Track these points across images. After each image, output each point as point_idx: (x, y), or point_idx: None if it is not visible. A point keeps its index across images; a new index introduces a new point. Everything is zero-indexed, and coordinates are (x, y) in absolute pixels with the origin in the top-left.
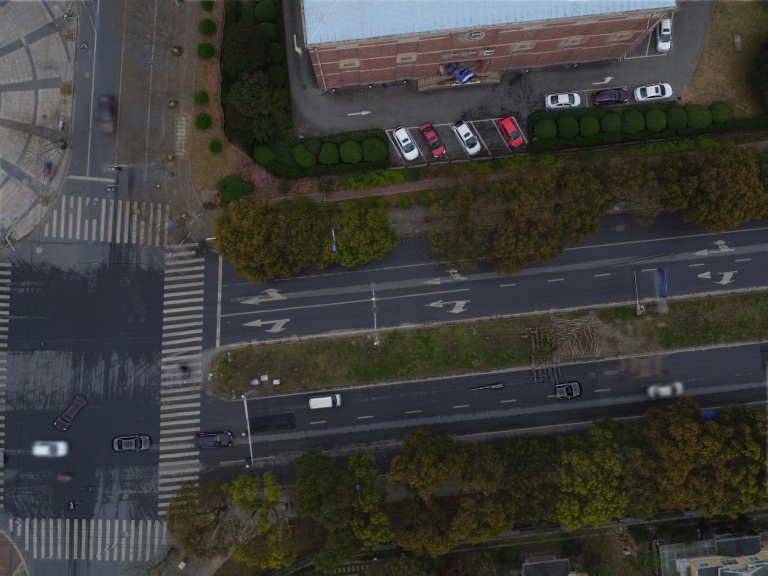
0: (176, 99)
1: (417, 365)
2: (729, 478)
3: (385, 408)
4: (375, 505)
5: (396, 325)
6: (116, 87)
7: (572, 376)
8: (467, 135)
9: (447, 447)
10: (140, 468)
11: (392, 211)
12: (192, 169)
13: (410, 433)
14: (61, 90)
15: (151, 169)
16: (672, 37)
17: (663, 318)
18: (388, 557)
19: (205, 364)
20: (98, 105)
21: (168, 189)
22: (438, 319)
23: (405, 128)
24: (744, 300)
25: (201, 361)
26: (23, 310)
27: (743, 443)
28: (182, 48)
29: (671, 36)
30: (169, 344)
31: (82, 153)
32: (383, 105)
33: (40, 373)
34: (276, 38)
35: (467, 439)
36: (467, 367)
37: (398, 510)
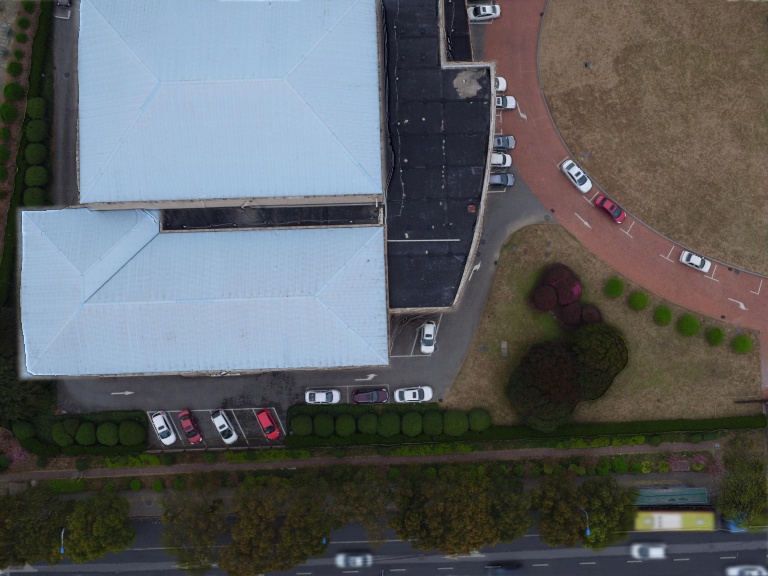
0: None
1: None
2: None
3: None
4: None
5: None
6: None
7: None
8: (222, 427)
9: None
10: None
11: (146, 493)
12: None
13: None
14: None
15: None
16: (438, 339)
17: None
18: None
19: None
20: None
21: None
22: None
23: (165, 412)
24: None
25: None
26: None
27: None
28: None
29: (435, 340)
30: None
31: None
32: (147, 386)
33: None
34: None
35: None
36: None
37: None
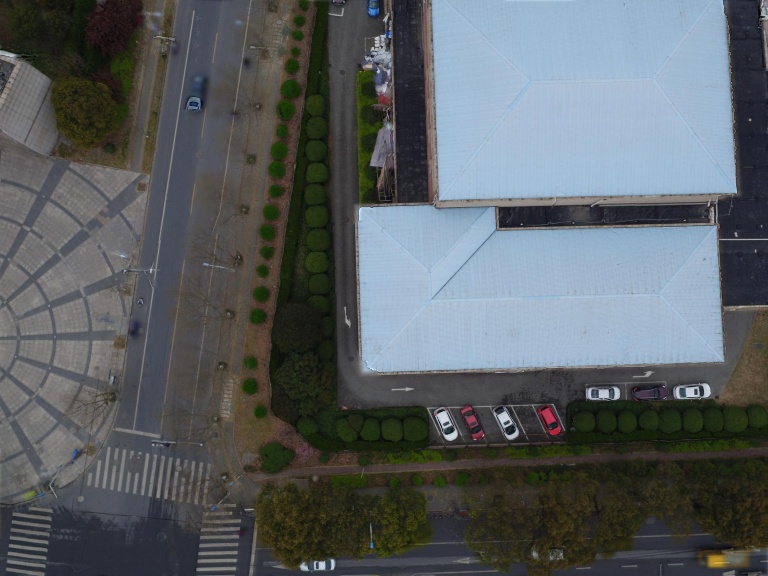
0: (226, 361)
1: None
2: None
3: None
4: None
5: None
6: (168, 344)
7: None
8: (507, 423)
9: None
10: None
11: (427, 488)
12: (236, 431)
13: None
14: (115, 343)
15: (196, 428)
16: None
17: None
18: None
19: None
20: (149, 360)
21: (211, 449)
22: None
23: (447, 408)
24: None
25: None
26: (60, 557)
27: None
28: (236, 312)
29: None
30: None
31: (130, 407)
32: (427, 383)
33: None
34: (328, 311)
35: None
36: None
37: None
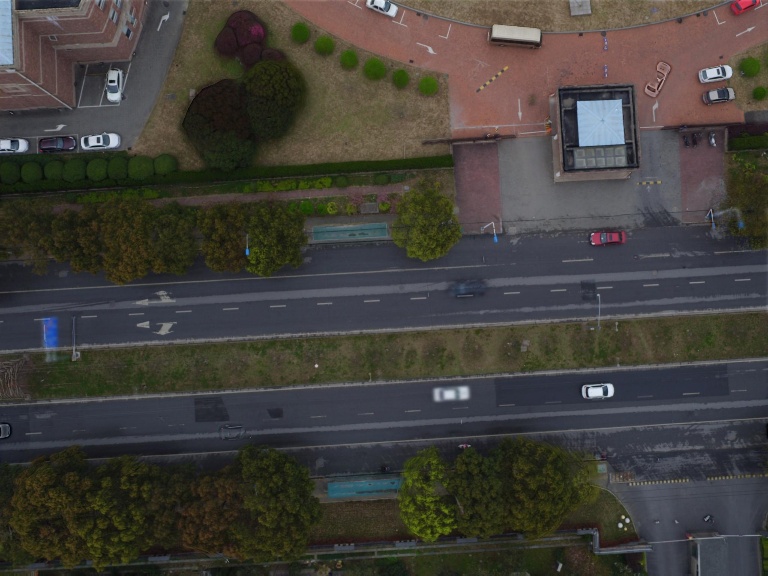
0: None
1: None
2: (76, 531)
3: None
4: None
5: None
6: None
7: (3, 418)
8: None
9: None
10: None
11: None
12: None
13: None
14: None
15: None
16: (126, 88)
17: (97, 365)
18: None
19: None
20: None
21: None
22: None
23: None
24: (180, 351)
25: None
26: None
27: (95, 497)
28: None
29: (121, 87)
30: None
31: None
32: None
33: None
34: None
35: None
36: None
37: None
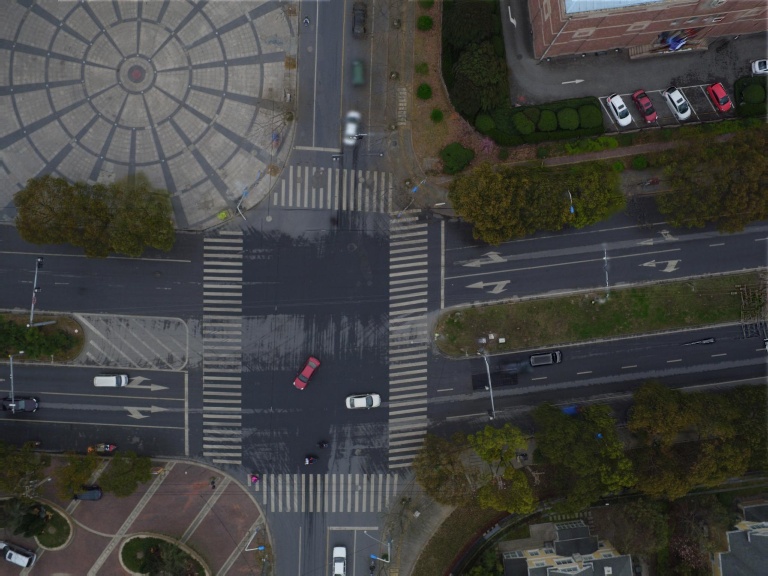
0: (397, 71)
1: (633, 322)
2: None
3: (603, 364)
4: (621, 451)
5: (612, 284)
6: (339, 60)
7: None
8: (680, 101)
9: (672, 398)
10: (371, 425)
11: (606, 175)
12: (414, 138)
13: (637, 385)
14: (286, 64)
15: (374, 139)
16: None
17: None
18: (627, 501)
19: (431, 325)
20: (321, 78)
21: (391, 158)
22: (651, 278)
23: None
24: None
25: (427, 322)
26: (255, 276)
27: None
28: (402, 21)
29: None
30: (395, 306)
31: (307, 124)
32: (596, 73)
33: (274, 336)
34: (494, 10)
35: (686, 391)
36: (680, 323)
37: (639, 456)
